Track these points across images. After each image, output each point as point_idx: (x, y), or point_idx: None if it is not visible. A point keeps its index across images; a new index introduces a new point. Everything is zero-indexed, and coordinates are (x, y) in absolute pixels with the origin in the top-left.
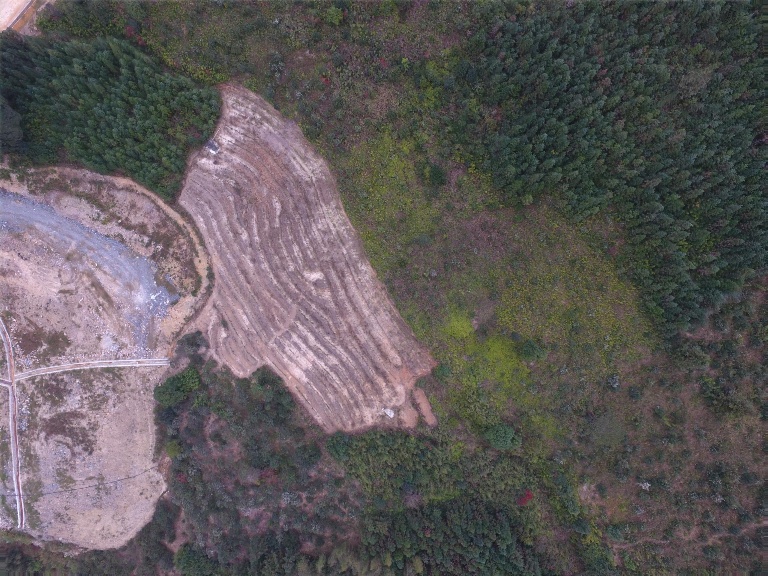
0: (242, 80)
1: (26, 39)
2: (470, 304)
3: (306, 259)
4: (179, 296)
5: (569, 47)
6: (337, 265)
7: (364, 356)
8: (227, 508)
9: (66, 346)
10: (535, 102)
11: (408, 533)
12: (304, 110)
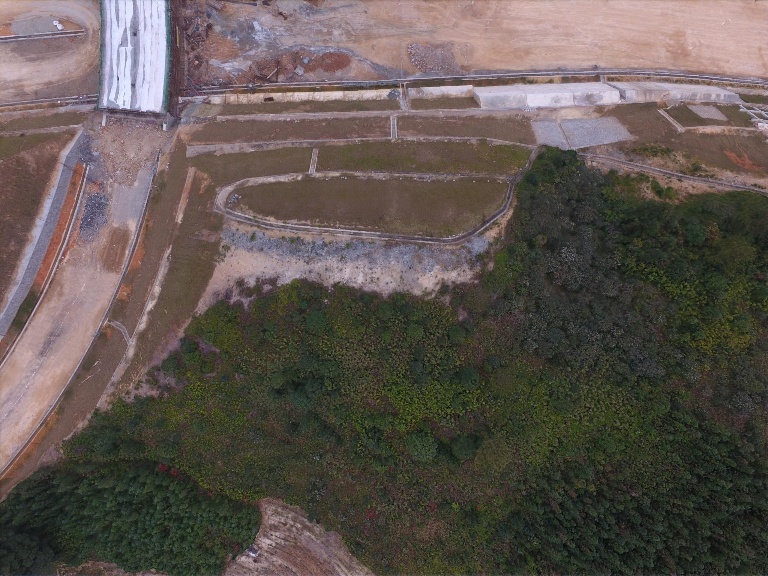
0: (281, 496)
1: (54, 473)
2: None
3: None
4: None
5: (638, 559)
6: None
7: None
8: None
9: None
10: None
11: None
12: (348, 532)
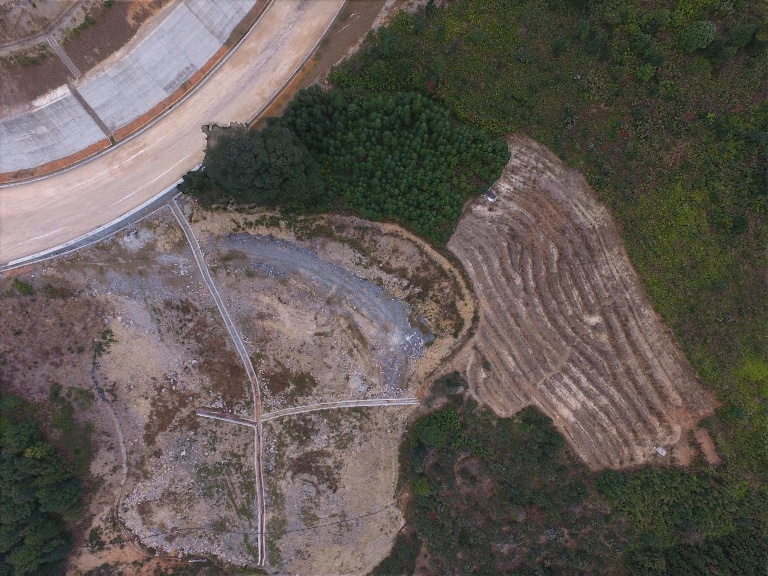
0: (530, 131)
1: (324, 94)
2: (767, 349)
3: (588, 304)
4: (434, 337)
5: None
6: (620, 310)
7: (639, 397)
8: (481, 544)
9: (313, 386)
10: None
11: (690, 569)
12: (595, 161)
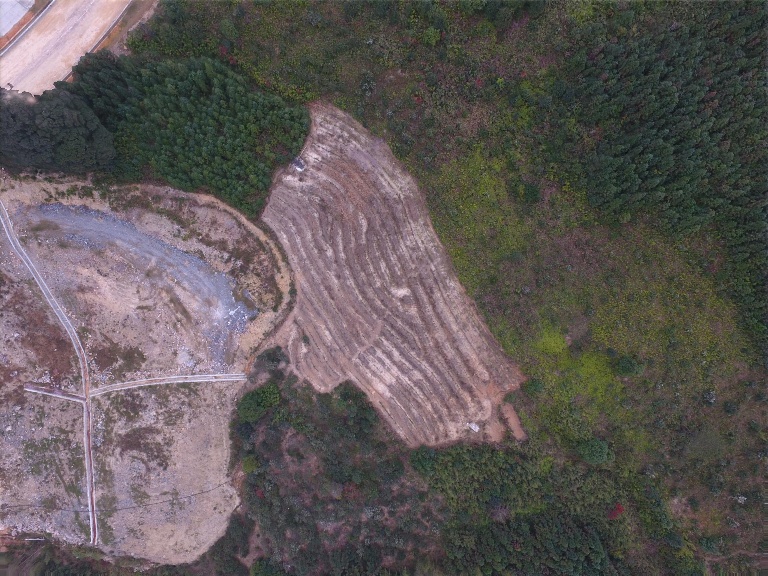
0: (331, 99)
1: (118, 59)
2: (563, 320)
3: (394, 275)
4: (258, 311)
5: (677, 70)
6: (425, 281)
7: (450, 371)
8: (306, 522)
9: (141, 361)
10: (638, 123)
11: (497, 547)
12: (395, 128)
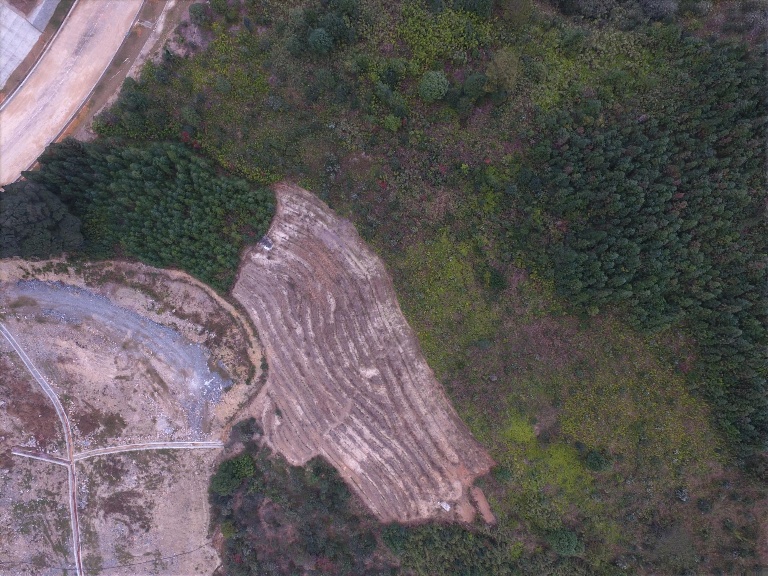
0: (296, 180)
1: None
2: (531, 409)
3: (362, 357)
4: (232, 382)
5: (643, 168)
6: (393, 363)
7: (420, 451)
8: None
9: (122, 427)
10: (604, 218)
11: None
12: (360, 211)
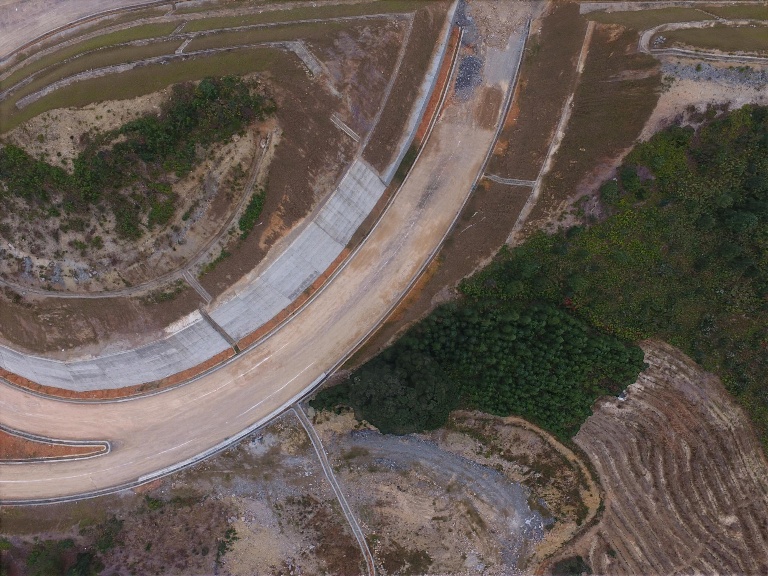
0: (665, 337)
1: None
2: None
3: (724, 506)
4: (555, 520)
5: None
6: (759, 513)
7: None
8: None
9: (428, 564)
10: None
11: None
12: (734, 369)
